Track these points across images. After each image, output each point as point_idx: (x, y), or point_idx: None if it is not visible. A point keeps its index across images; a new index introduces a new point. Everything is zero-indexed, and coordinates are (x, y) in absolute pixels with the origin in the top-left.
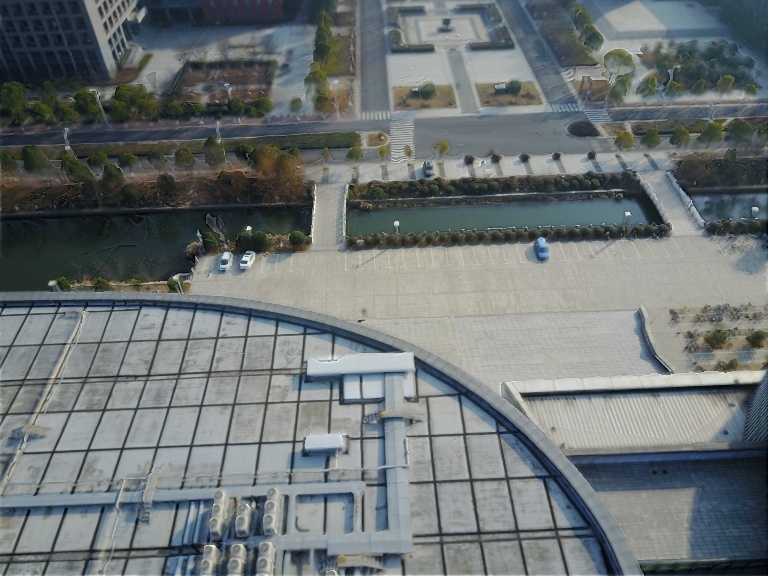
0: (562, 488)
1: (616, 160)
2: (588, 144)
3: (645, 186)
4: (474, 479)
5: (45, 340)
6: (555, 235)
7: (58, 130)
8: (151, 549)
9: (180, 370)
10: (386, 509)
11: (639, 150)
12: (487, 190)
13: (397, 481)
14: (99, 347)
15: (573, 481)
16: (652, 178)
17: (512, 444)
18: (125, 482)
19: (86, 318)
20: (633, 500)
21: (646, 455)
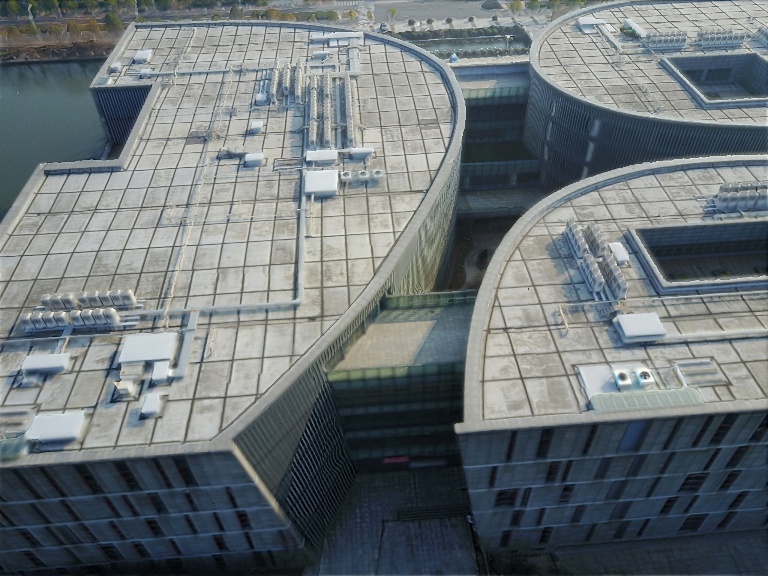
0: (427, 62)
1: (511, 21)
2: (494, 13)
3: (527, 32)
4: (389, 62)
5: (178, 37)
6: (464, 54)
7: (120, 15)
8: (248, 81)
9: (249, 43)
10: (349, 68)
11: (528, 15)
12: (423, 36)
13: (354, 61)
14: (206, 38)
15: (431, 57)
16: (533, 28)
17: (407, 54)
18: (232, 65)
19: (196, 30)
20: (465, 84)
21: (473, 69)
